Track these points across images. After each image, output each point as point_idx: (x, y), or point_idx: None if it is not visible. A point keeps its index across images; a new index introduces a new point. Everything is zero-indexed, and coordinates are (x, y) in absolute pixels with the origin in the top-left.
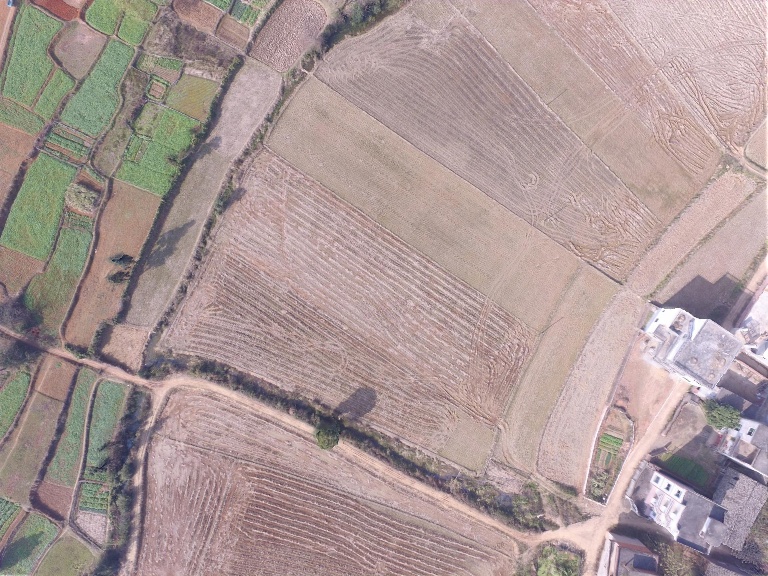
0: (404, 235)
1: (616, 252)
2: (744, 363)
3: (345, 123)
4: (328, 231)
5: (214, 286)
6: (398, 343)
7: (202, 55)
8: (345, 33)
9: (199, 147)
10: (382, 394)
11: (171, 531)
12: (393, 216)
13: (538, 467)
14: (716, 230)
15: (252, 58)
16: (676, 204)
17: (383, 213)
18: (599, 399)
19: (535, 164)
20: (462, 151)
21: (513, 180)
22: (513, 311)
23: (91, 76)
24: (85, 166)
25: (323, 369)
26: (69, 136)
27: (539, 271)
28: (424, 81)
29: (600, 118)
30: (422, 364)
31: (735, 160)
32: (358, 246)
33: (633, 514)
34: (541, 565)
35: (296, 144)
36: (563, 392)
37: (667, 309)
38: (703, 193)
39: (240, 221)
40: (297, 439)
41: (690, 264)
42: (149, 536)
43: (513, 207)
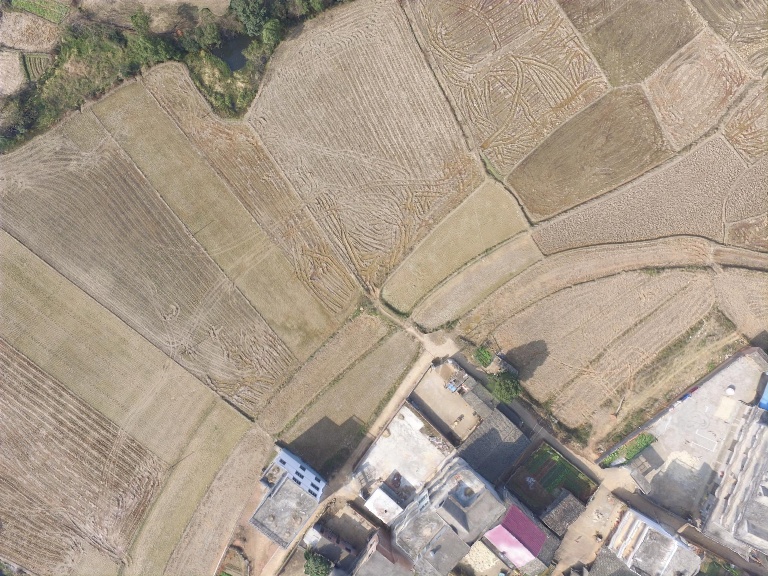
0: (40, 362)
1: (251, 388)
2: None
3: None
4: None
5: None
6: (28, 472)
7: None
8: None
9: None
10: (8, 523)
11: None
12: (30, 342)
13: None
14: (345, 372)
15: None
16: (313, 342)
17: (20, 338)
18: (223, 536)
19: (177, 295)
20: (105, 278)
21: (154, 310)
22: (146, 443)
23: None
24: None
25: None
26: None
27: (174, 404)
28: (70, 204)
29: (244, 251)
30: (51, 494)
31: (369, 302)
32: None
33: None
34: None
35: None
36: (187, 528)
37: (279, 454)
38: (338, 333)
39: None
40: None
41: (318, 405)
42: None
43: (152, 338)
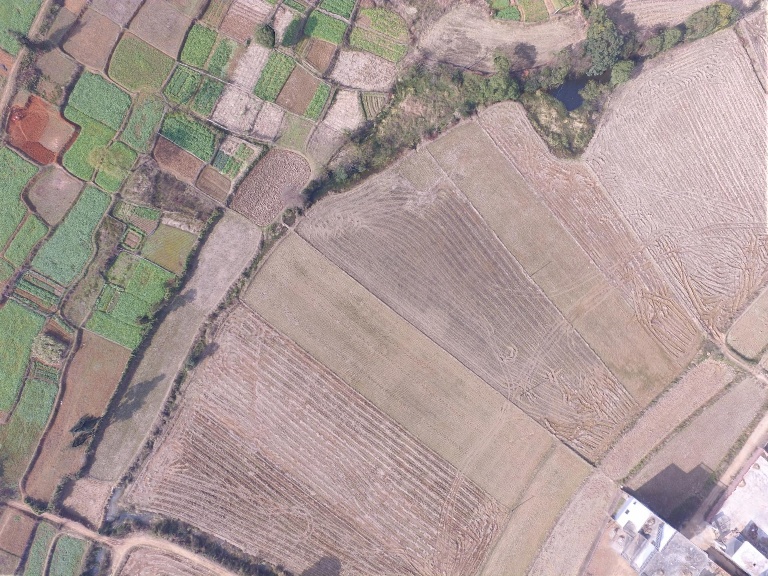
0: (378, 401)
1: (591, 432)
2: (712, 561)
3: (324, 282)
4: (301, 393)
5: (181, 443)
6: (366, 512)
7: (181, 206)
8: (329, 189)
9: (173, 299)
10: (347, 564)
11: None
12: (368, 381)
13: None
14: (693, 418)
15: (232, 210)
16: (654, 387)
17: (358, 378)
18: None
19: (514, 336)
20: (441, 318)
21: (491, 351)
22: (484, 486)
23: (65, 223)
24: (54, 316)
25: (288, 535)
26: (39, 283)
27: (512, 447)
28: (407, 244)
29: (583, 293)
30: (389, 535)
31: (716, 347)
32: (330, 410)
33: None
34: None
35: (273, 301)
36: (530, 573)
37: (638, 503)
38: (682, 378)
39: (211, 377)
40: None
41: (665, 451)
42: None
43: (490, 379)
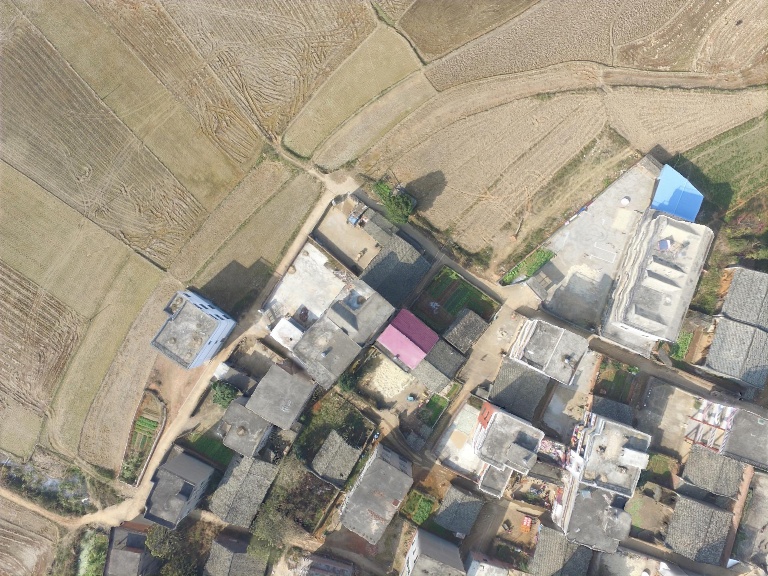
0: None
1: (163, 240)
2: (262, 344)
3: None
4: None
5: None
6: None
7: None
8: None
9: None
10: None
11: None
12: None
13: (79, 451)
14: (251, 216)
15: None
16: (220, 192)
17: None
18: (140, 383)
19: (89, 157)
20: (21, 146)
21: (68, 173)
22: (64, 299)
23: None
24: None
25: None
26: None
27: (90, 260)
28: None
29: (151, 111)
30: None
31: (271, 149)
32: None
33: None
34: (84, 549)
35: None
36: (106, 377)
37: None
38: (243, 181)
39: None
40: None
41: (226, 250)
42: None
43: (67, 199)
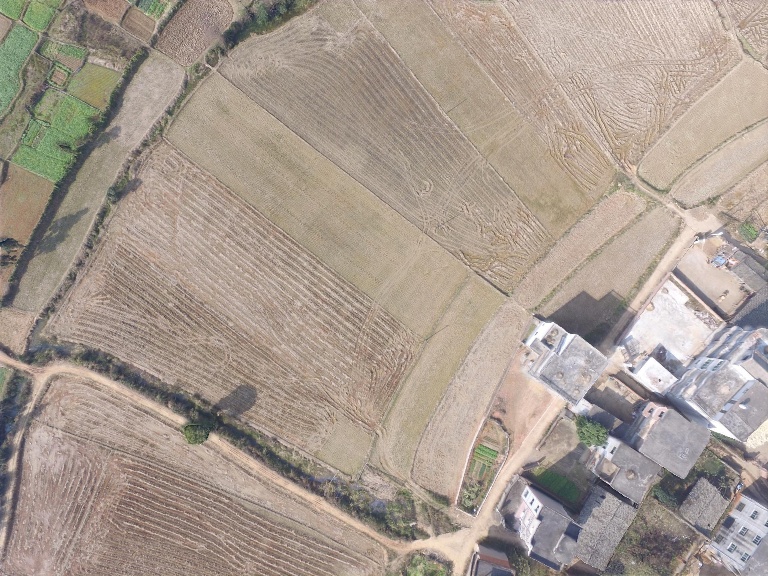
0: (296, 235)
1: (505, 263)
2: (620, 381)
3: (245, 120)
4: (221, 226)
5: (103, 275)
6: (282, 342)
7: (106, 45)
8: (251, 31)
9: (98, 136)
10: (263, 392)
11: (42, 519)
12: (286, 215)
13: (413, 475)
14: (604, 247)
15: (157, 50)
16: (567, 219)
17: (276, 211)
18: (478, 410)
19: (430, 171)
20: (359, 154)
21: (407, 186)
22: (399, 317)
23: None
24: None
25: (206, 364)
26: None
27: (427, 278)
28: (326, 83)
29: (497, 129)
30: (305, 365)
31: (627, 178)
32: (249, 243)
33: (503, 527)
34: (410, 574)
35: (195, 138)
36: (442, 401)
37: (546, 323)
38: (594, 209)
39: (134, 211)
40: (175, 433)
41: (576, 279)
42: (20, 523)
43: (406, 213)
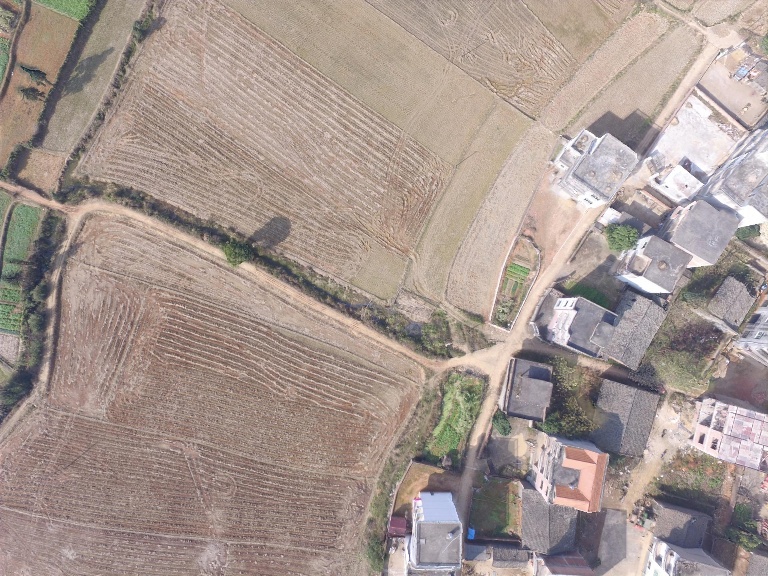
0: (323, 68)
1: (531, 89)
2: (648, 192)
3: None
4: (247, 62)
5: (132, 114)
6: (314, 174)
7: None
8: None
9: None
10: (297, 224)
11: (84, 354)
12: (312, 49)
13: (447, 296)
14: (628, 67)
15: None
16: (591, 43)
17: (303, 46)
18: (509, 231)
19: (455, 1)
20: None
21: (432, 16)
22: (428, 145)
23: None
24: None
25: (239, 198)
26: None
27: (455, 106)
28: None
29: None
30: (337, 195)
31: None
32: (277, 78)
33: (536, 340)
34: (447, 392)
35: None
36: (474, 223)
37: None
38: (617, 32)
39: (160, 50)
40: (211, 266)
41: (601, 100)
42: (62, 358)
43: (431, 43)
